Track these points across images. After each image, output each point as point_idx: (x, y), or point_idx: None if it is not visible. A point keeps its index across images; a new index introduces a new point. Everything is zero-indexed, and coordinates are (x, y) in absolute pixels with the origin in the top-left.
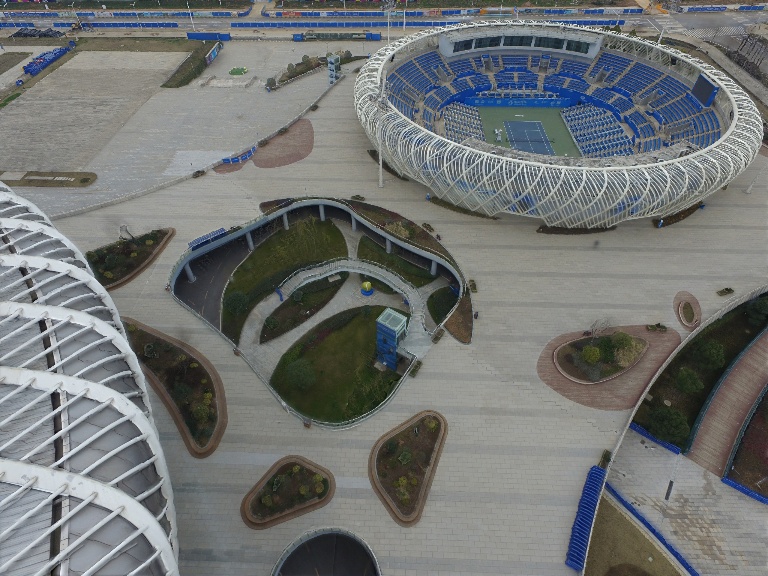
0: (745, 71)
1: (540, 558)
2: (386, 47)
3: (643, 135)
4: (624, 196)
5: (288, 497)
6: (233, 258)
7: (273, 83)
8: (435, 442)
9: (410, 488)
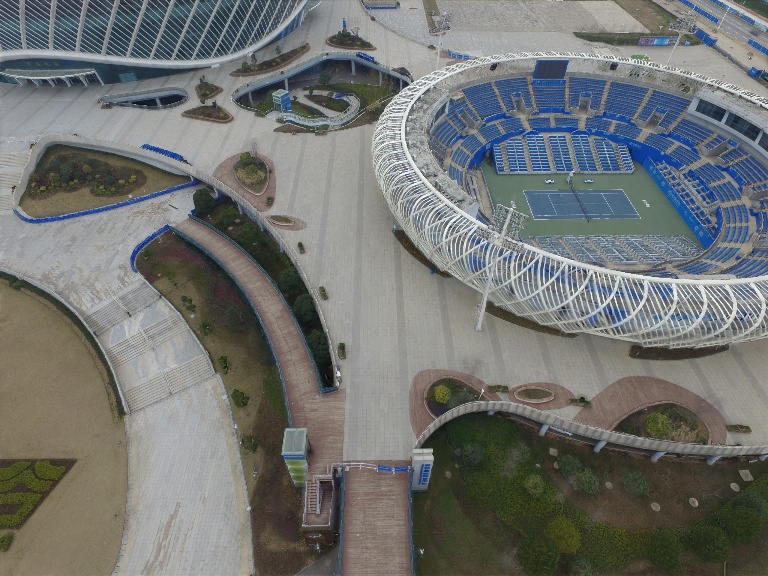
0: None
1: (153, 142)
2: None
3: None
4: None
5: None
6: (372, 81)
7: None
8: (215, 118)
9: (194, 110)
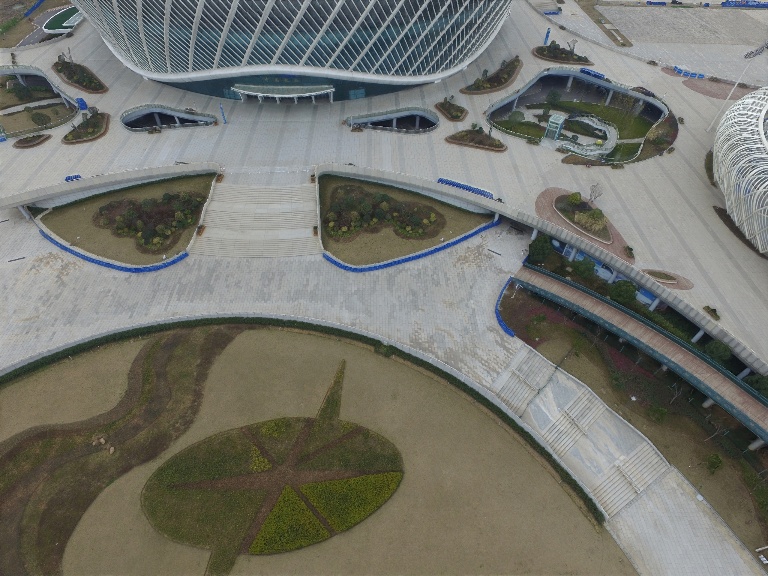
0: None
1: (440, 175)
2: None
3: None
4: None
5: (449, 108)
6: (593, 100)
7: None
8: (489, 146)
9: (461, 135)
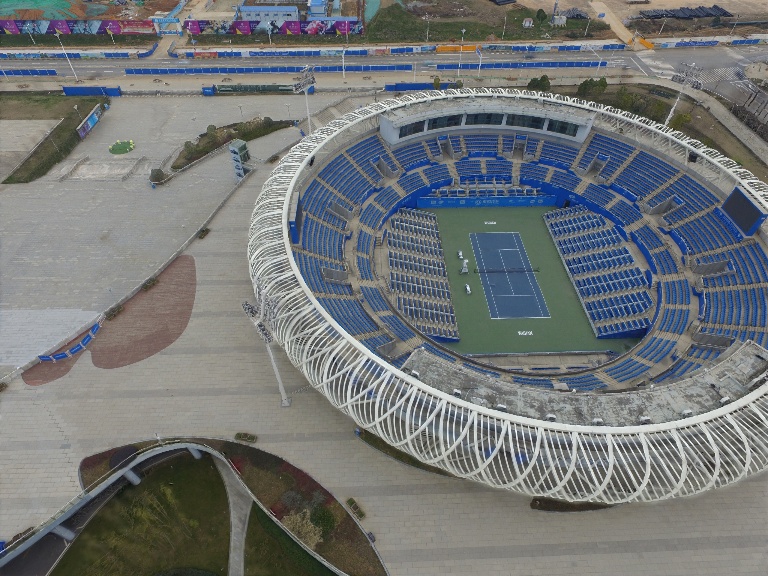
0: (757, 136)
1: None
2: (303, 143)
3: (661, 269)
4: (679, 488)
5: None
6: (34, 565)
7: (159, 176)
8: None
9: None
